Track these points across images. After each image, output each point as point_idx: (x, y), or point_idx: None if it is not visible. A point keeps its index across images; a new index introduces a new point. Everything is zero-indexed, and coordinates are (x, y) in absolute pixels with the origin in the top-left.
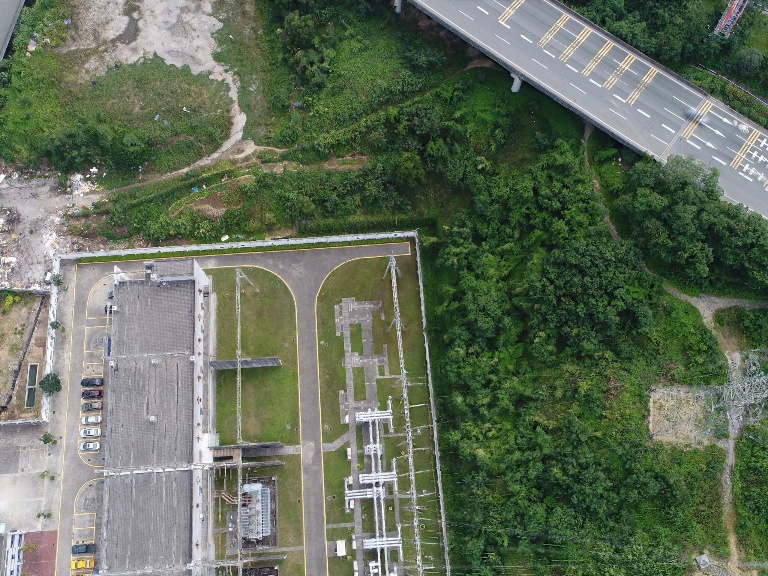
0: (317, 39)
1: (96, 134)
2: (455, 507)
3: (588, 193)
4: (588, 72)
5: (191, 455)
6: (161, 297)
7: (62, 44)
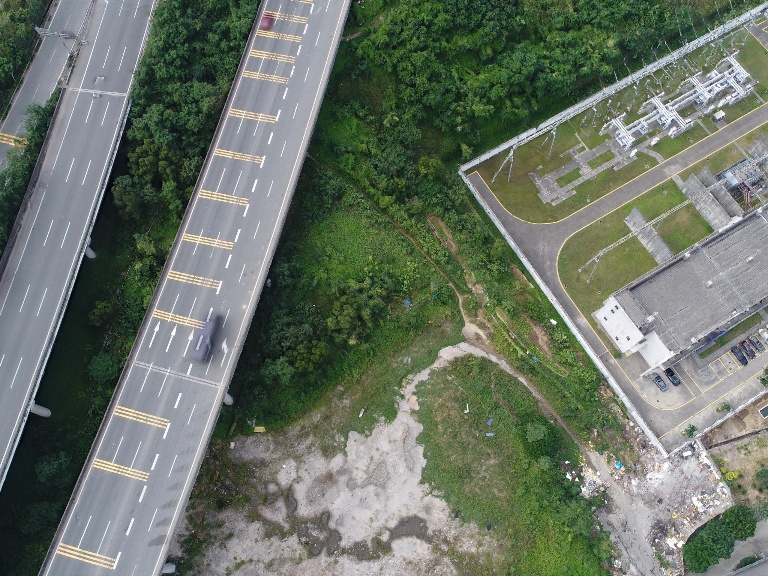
0: None
1: None
2: (641, 64)
3: (407, 6)
4: (298, 38)
5: (751, 219)
6: None
7: None
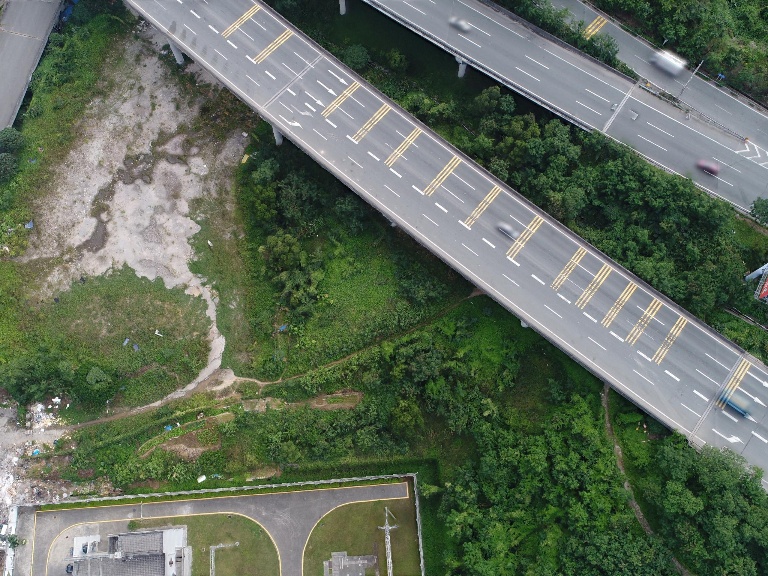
0: (304, 256)
1: (57, 370)
2: None
3: (610, 474)
4: (608, 322)
5: None
6: (126, 574)
7: (22, 253)
